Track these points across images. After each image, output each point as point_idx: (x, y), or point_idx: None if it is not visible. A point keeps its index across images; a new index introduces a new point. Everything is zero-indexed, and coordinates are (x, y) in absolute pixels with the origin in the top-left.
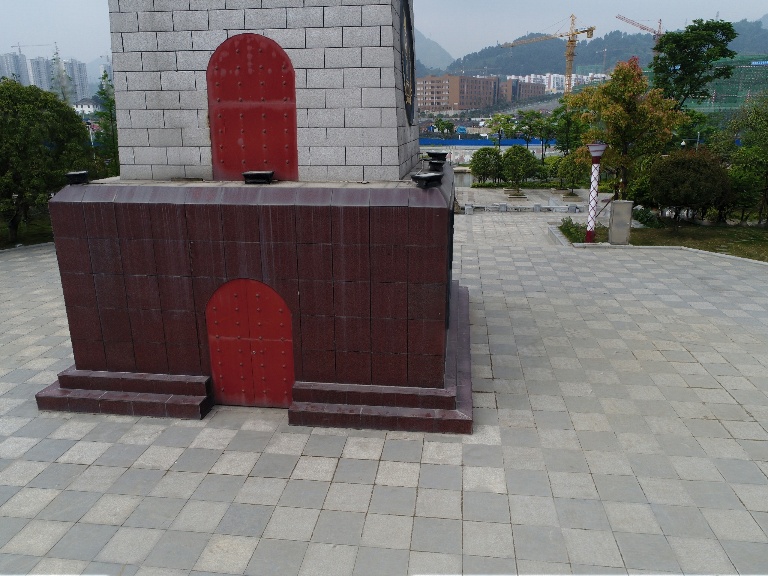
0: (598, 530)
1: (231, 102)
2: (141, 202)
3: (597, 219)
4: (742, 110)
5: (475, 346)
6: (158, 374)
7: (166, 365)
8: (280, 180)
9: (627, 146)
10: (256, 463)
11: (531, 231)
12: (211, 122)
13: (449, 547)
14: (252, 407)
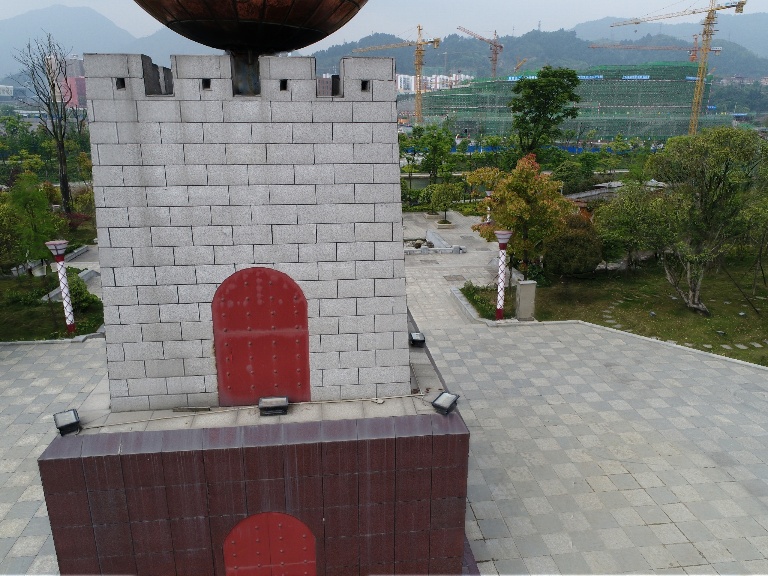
0: None
1: (239, 331)
2: (152, 452)
3: (486, 269)
4: (617, 196)
5: None
6: None
7: None
8: (292, 402)
9: (527, 231)
10: None
11: (434, 292)
12: (217, 351)
13: None
14: None
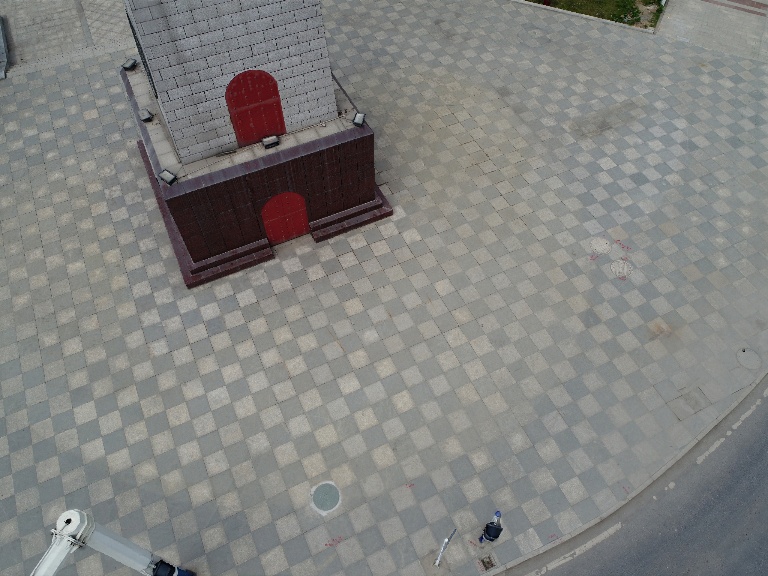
0: (457, 241)
1: (242, 107)
2: (221, 182)
3: None
4: None
5: None
6: (240, 247)
7: (243, 242)
8: (277, 136)
9: None
10: (323, 269)
11: None
12: (232, 120)
13: (418, 270)
14: (289, 241)
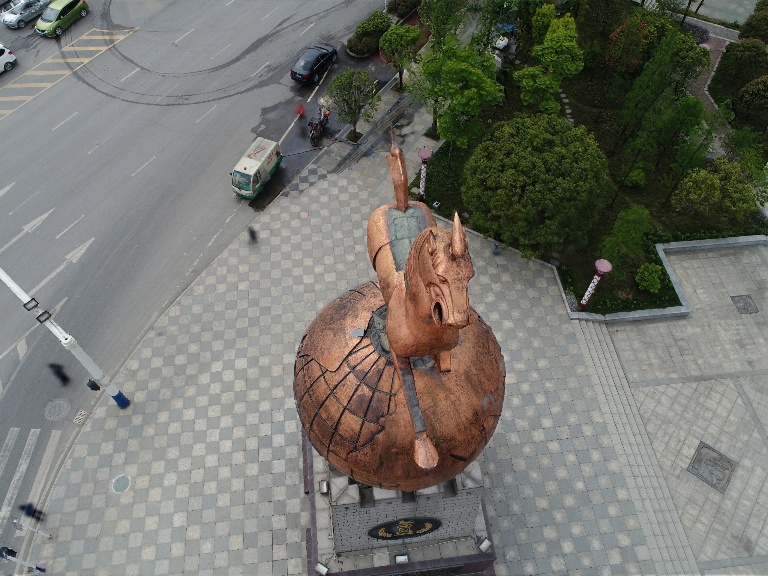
0: None
1: None
2: None
3: None
4: None
5: None
6: None
7: None
8: None
9: None
10: (280, 529)
11: None
12: None
13: None
14: None
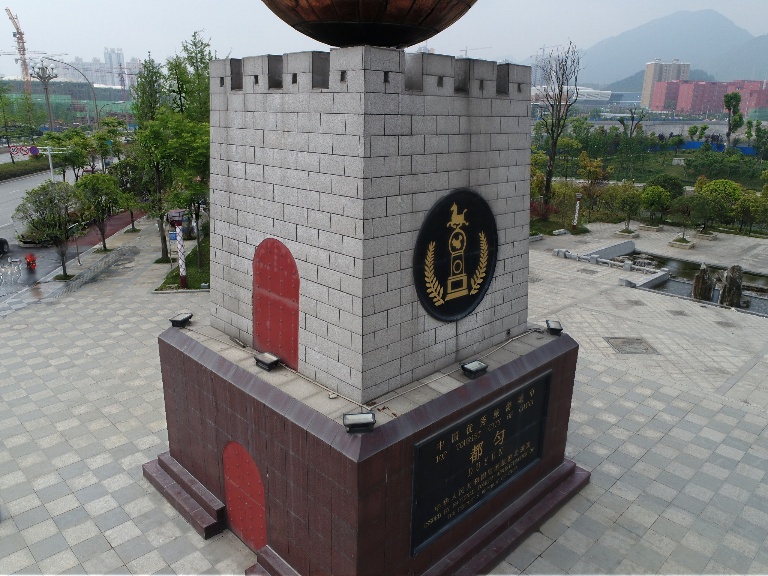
0: None
1: (264, 290)
2: (193, 358)
3: None
4: None
5: (504, 568)
6: (202, 485)
7: (206, 481)
8: (288, 366)
9: None
10: None
11: None
12: (254, 302)
13: None
14: (246, 545)
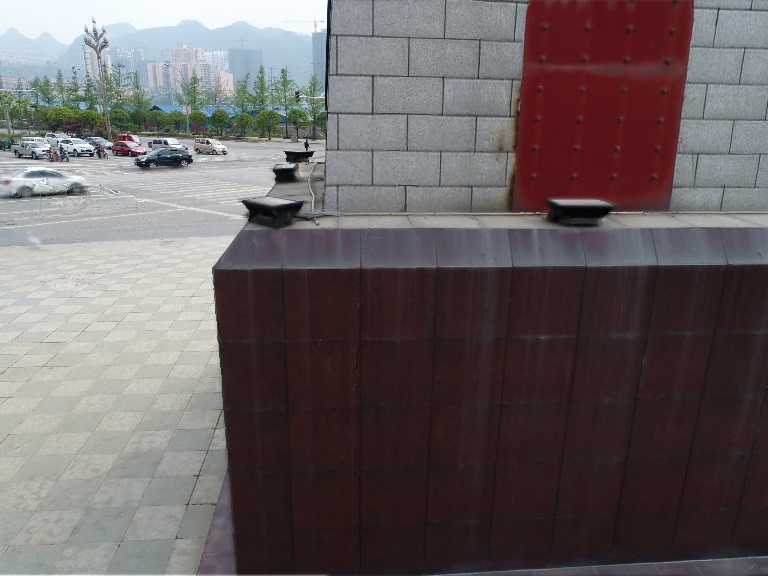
0: None
1: None
2: None
3: None
4: None
5: None
6: None
7: None
8: None
9: None
10: None
11: None
12: None
13: None
14: None
